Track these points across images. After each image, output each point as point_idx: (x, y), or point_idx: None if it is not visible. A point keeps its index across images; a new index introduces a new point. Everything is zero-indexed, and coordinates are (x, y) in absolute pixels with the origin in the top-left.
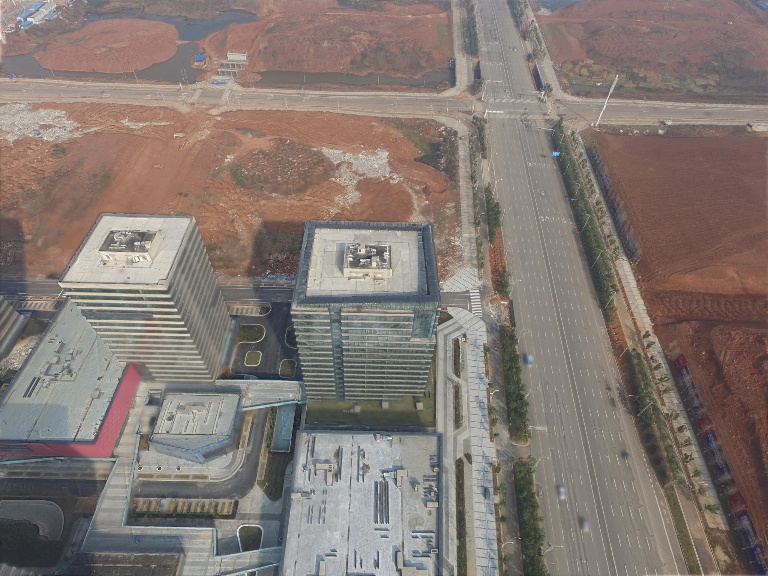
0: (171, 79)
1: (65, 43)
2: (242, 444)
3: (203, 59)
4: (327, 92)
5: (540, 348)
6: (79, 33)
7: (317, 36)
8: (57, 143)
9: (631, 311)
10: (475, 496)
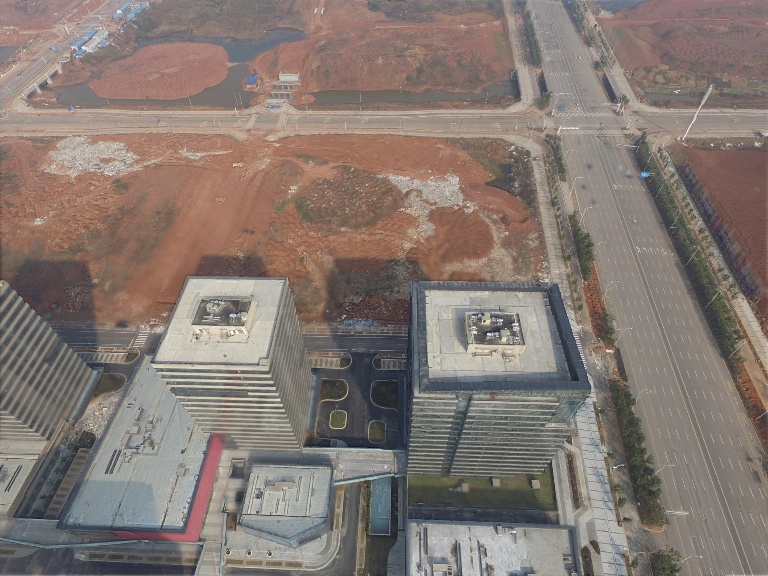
0: (225, 104)
1: (118, 70)
2: (336, 524)
3: (255, 81)
4: (385, 112)
5: (659, 407)
6: (131, 59)
7: (370, 53)
8: (118, 178)
9: (760, 361)
10: None
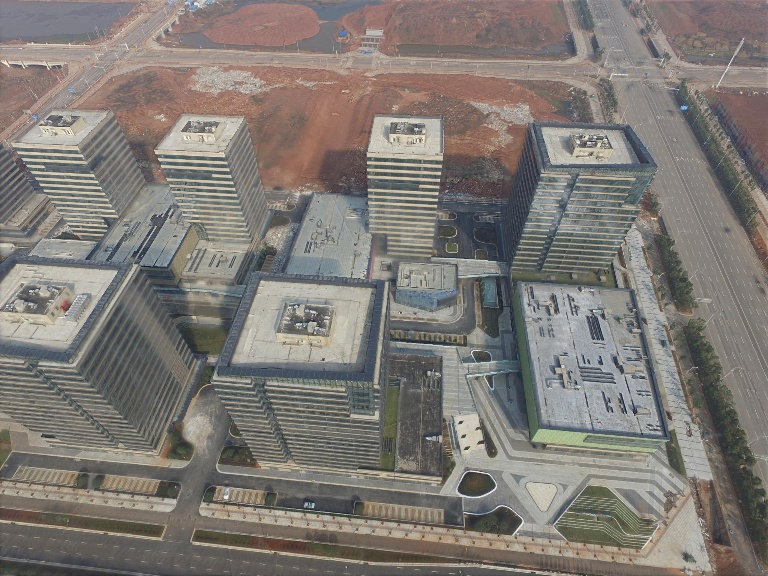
0: (323, 50)
1: (226, 23)
2: (459, 302)
3: (345, 35)
4: (462, 60)
5: (692, 251)
6: (235, 15)
7: (445, 14)
8: (253, 95)
9: None
10: (654, 345)
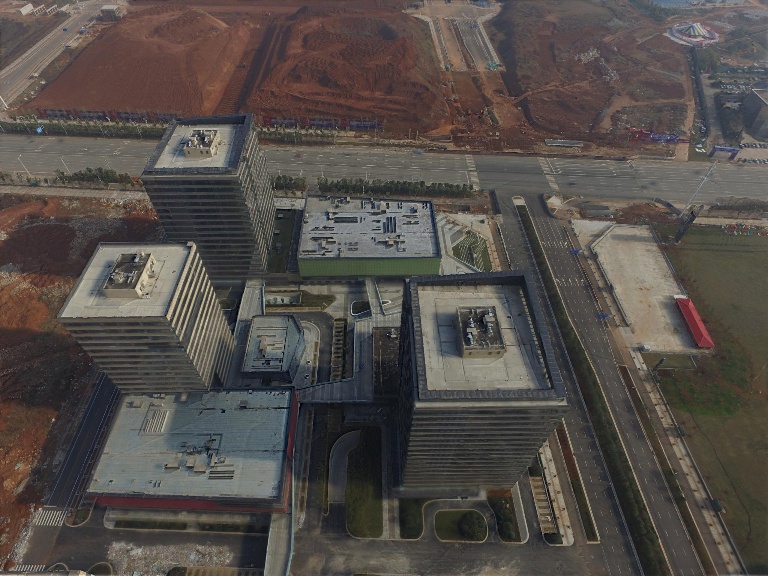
0: None
1: None
2: None
3: None
4: None
5: None
6: None
7: None
8: None
9: None
10: None
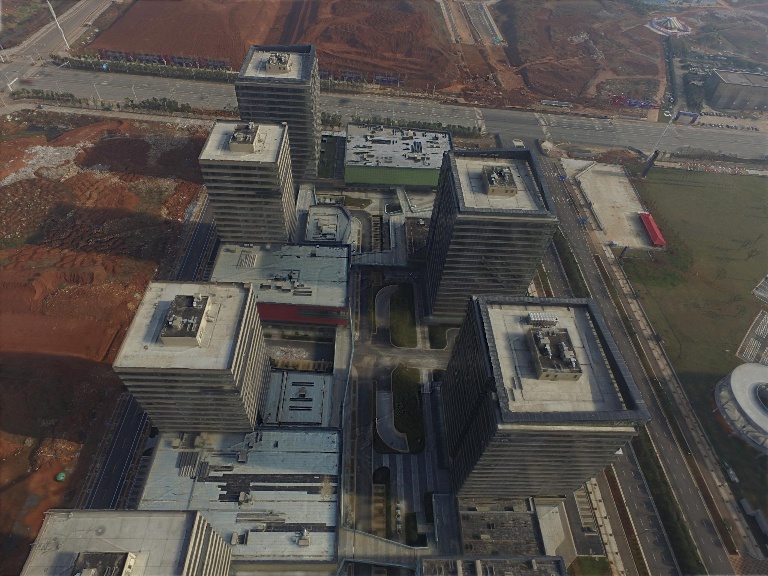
0: None
1: None
2: None
3: None
4: None
5: None
6: None
7: None
8: None
9: None
10: None
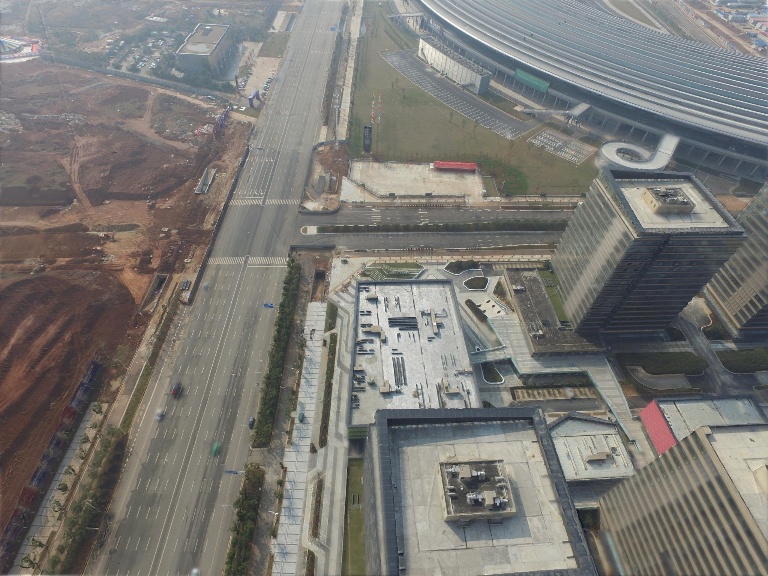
0: None
1: None
2: None
3: None
4: None
5: None
6: None
7: None
8: None
9: None
10: (312, 415)
